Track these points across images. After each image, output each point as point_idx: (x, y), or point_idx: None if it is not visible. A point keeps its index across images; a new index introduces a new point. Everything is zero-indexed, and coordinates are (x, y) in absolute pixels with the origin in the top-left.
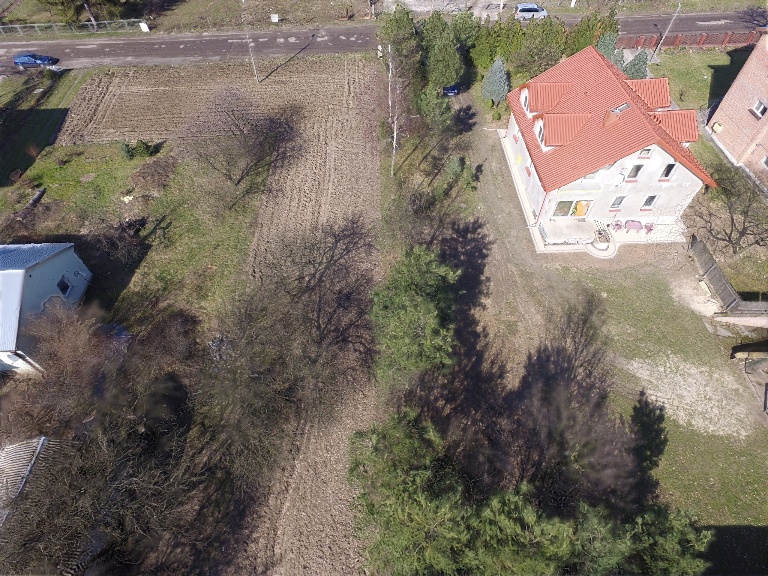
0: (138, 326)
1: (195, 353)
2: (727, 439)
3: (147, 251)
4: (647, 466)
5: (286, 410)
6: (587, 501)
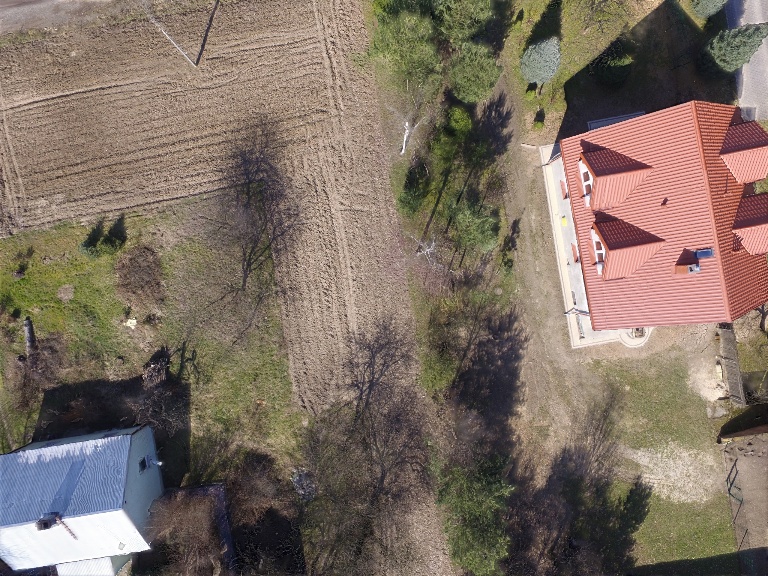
0: (222, 472)
1: (282, 489)
2: (692, 505)
3: (189, 392)
4: (630, 531)
5: (370, 525)
6: (586, 558)
